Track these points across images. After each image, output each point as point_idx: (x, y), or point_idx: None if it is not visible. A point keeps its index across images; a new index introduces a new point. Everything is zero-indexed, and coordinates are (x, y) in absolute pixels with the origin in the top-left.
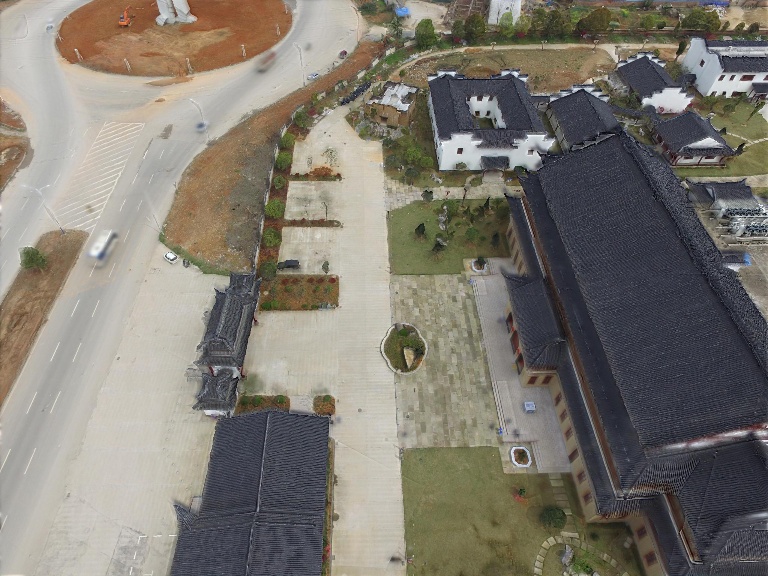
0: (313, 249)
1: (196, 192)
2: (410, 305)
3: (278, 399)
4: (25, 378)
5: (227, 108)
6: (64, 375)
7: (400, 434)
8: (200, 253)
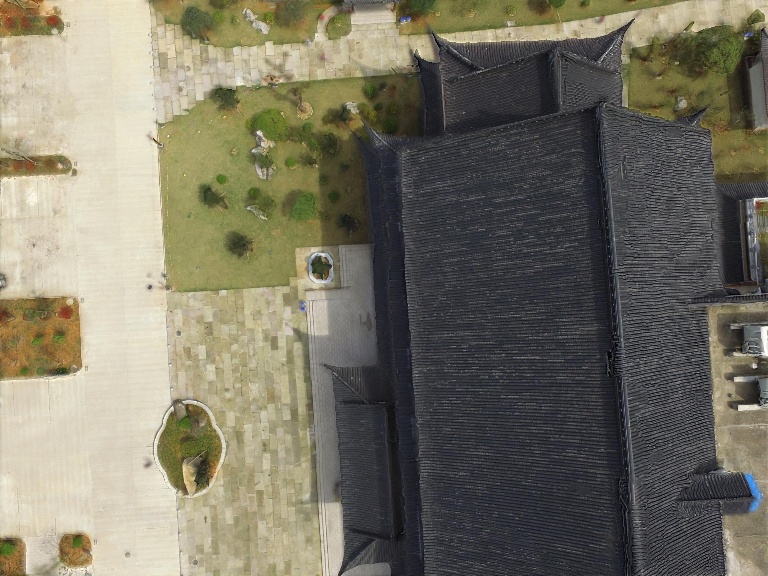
0: (26, 236)
1: None
2: (200, 360)
3: (4, 553)
4: None
5: None
6: None
7: None
8: None
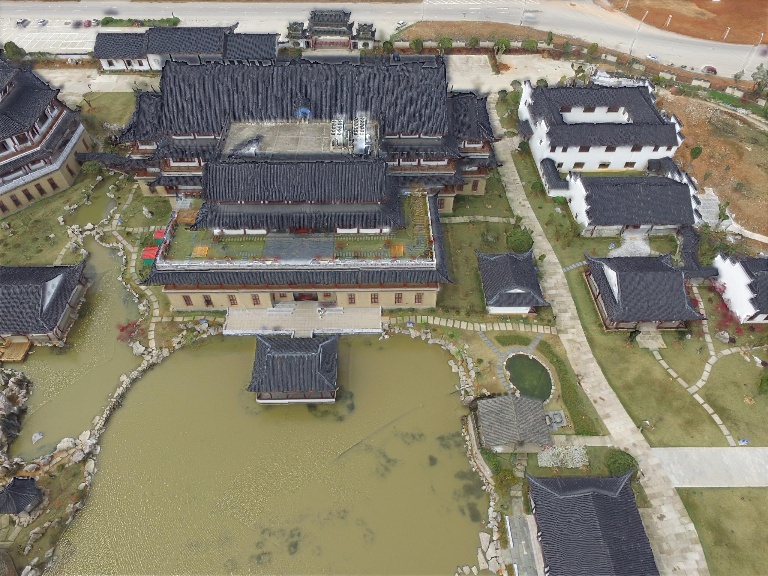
0: None
1: (465, 26)
2: None
3: None
4: None
5: (576, 28)
6: None
7: None
8: (406, 32)
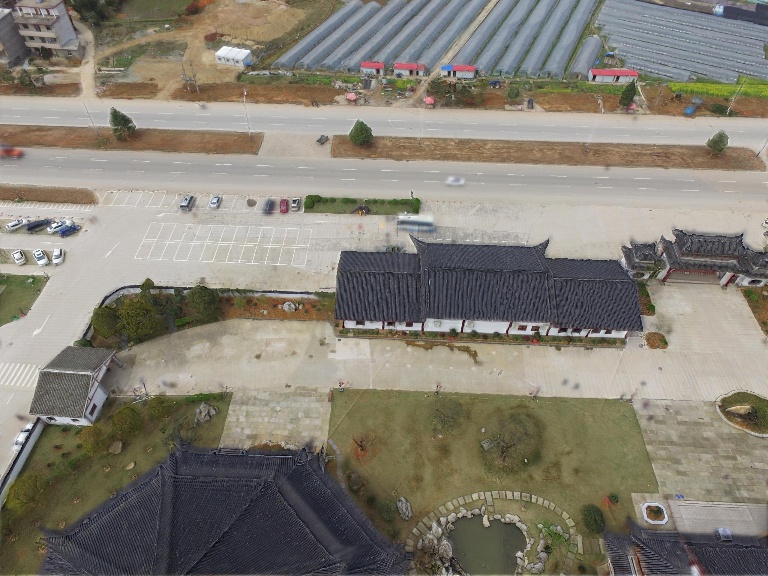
0: None
1: None
2: None
3: (650, 305)
4: (617, 170)
5: None
6: (626, 187)
7: (646, 401)
8: None
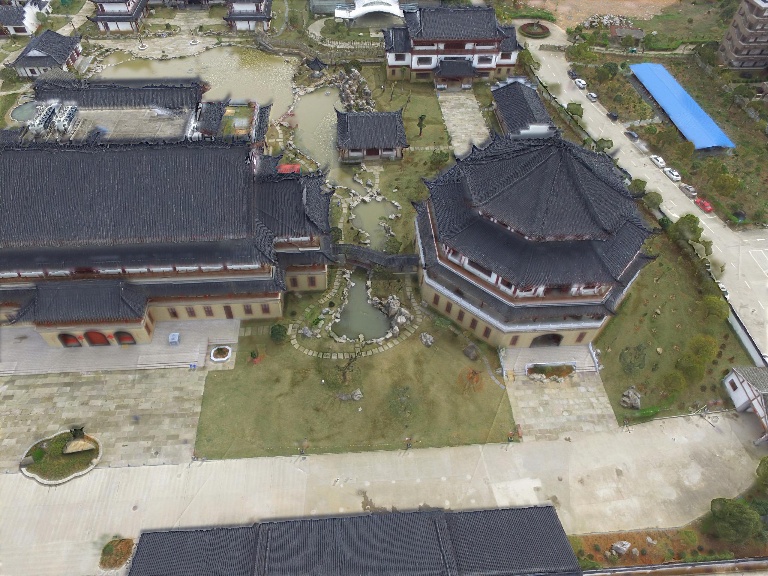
0: None
1: None
2: None
3: None
4: None
5: None
6: None
7: (175, 461)
8: None
